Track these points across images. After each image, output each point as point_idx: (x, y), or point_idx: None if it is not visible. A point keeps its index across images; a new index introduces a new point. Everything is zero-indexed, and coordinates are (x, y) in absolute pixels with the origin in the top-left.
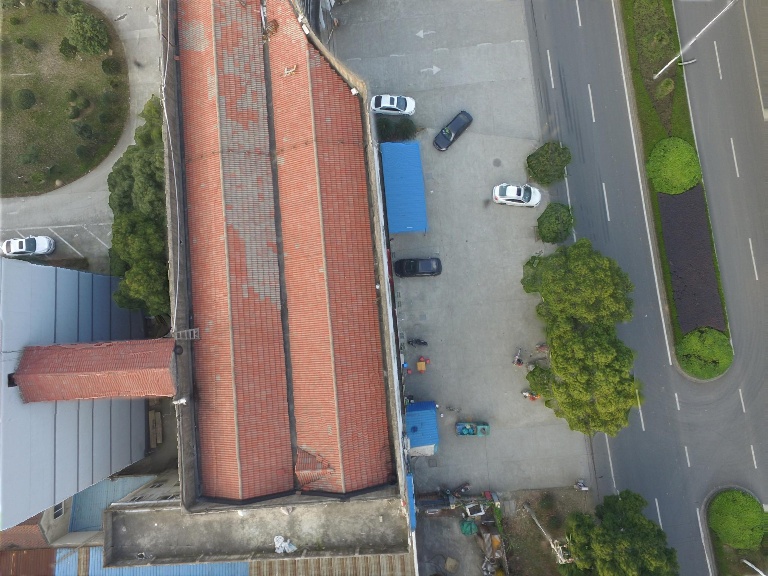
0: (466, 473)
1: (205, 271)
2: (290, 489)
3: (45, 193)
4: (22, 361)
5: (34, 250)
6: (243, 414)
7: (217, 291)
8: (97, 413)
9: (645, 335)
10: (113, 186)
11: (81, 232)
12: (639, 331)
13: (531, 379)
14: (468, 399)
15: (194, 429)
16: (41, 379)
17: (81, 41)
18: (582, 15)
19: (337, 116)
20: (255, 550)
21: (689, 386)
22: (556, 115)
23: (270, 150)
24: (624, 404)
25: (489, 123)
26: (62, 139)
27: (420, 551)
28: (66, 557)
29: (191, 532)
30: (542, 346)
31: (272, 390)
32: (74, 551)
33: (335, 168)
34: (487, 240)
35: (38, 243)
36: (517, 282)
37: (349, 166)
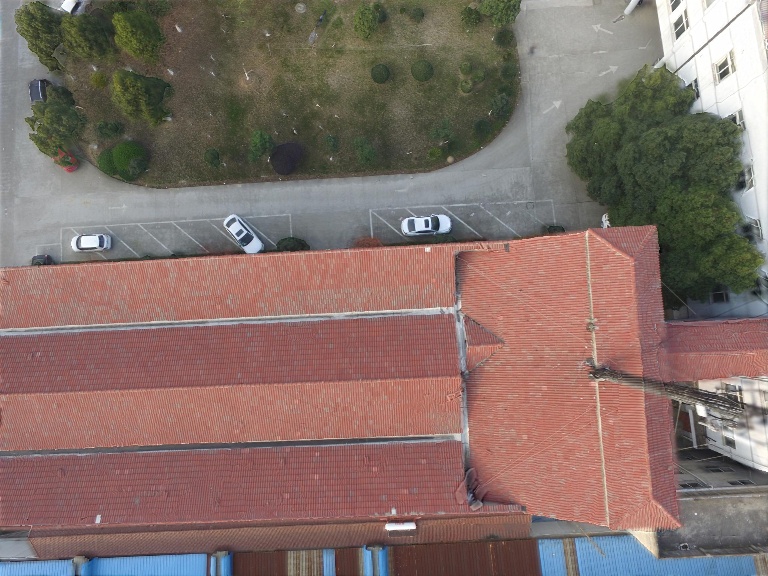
0: None
1: None
2: None
3: (435, 170)
4: None
5: (437, 229)
6: None
7: None
8: None
9: None
10: (634, 159)
11: (478, 211)
12: None
13: None
14: None
15: None
16: (680, 358)
17: (500, 10)
18: None
19: None
20: None
21: None
22: None
23: None
24: None
25: None
26: (452, 114)
27: None
28: (550, 548)
29: (735, 522)
30: None
31: None
32: (558, 542)
33: None
34: None
35: (441, 222)
36: None
37: None
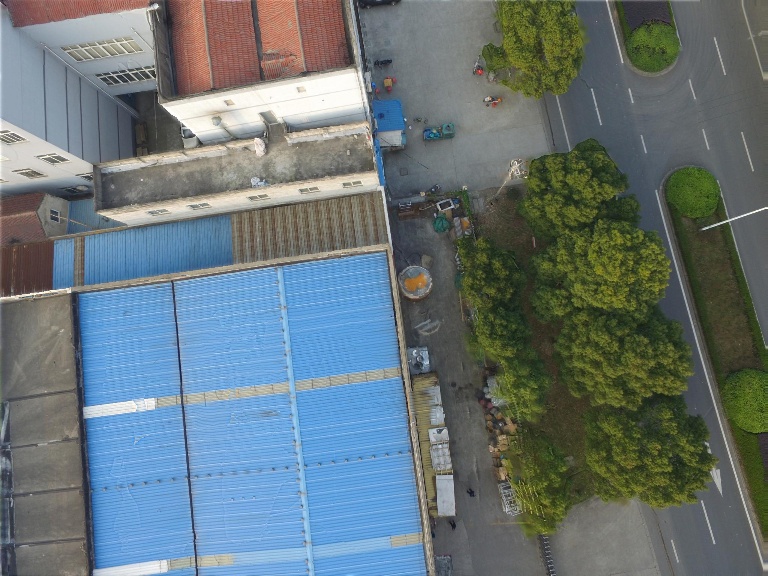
0: (436, 178)
1: None
2: None
3: None
4: None
5: None
6: (211, 18)
7: None
8: (85, 102)
9: (596, 35)
10: None
11: None
12: (588, 22)
13: (485, 50)
14: (434, 112)
15: (169, 49)
16: None
17: None
18: None
19: None
20: None
21: (641, 81)
22: None
23: None
24: (569, 38)
25: None
26: None
27: (392, 221)
28: (63, 247)
29: (174, 183)
30: None
31: (237, 3)
32: (70, 241)
33: None
34: None
35: None
36: (474, 4)
37: None
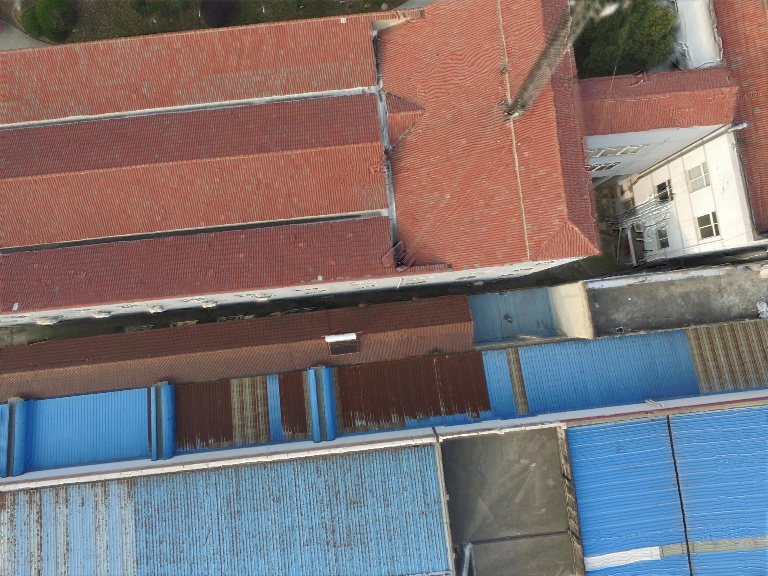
0: None
1: (725, 7)
2: None
3: None
4: None
5: None
6: None
7: (747, 24)
8: None
9: None
10: None
11: None
12: None
13: None
14: None
15: None
16: (596, 107)
17: None
18: None
19: None
20: (738, 317)
21: None
22: None
23: None
24: None
25: None
26: None
27: None
28: (493, 359)
29: (668, 304)
30: None
31: None
32: (501, 352)
33: None
34: None
35: None
36: None
37: None
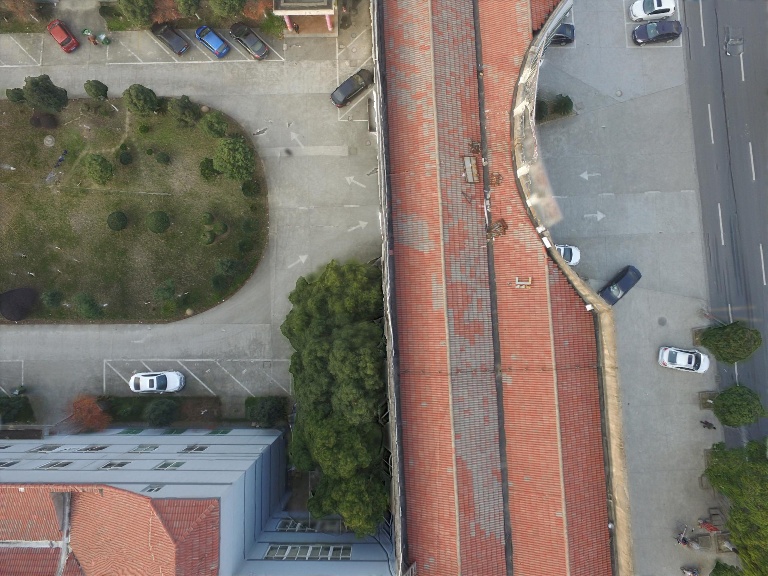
0: None
1: (425, 501)
2: None
3: (174, 322)
4: None
5: (165, 388)
6: None
7: (441, 527)
8: None
9: None
10: (296, 370)
11: (213, 368)
12: None
13: None
14: None
15: None
16: None
17: (229, 169)
18: (756, 169)
19: (574, 337)
20: None
21: None
22: (725, 274)
23: (494, 364)
24: None
25: (655, 278)
26: (194, 264)
27: None
28: None
29: None
30: (706, 522)
31: None
32: None
33: (572, 397)
34: (650, 404)
35: (169, 381)
36: (680, 451)
37: (585, 393)
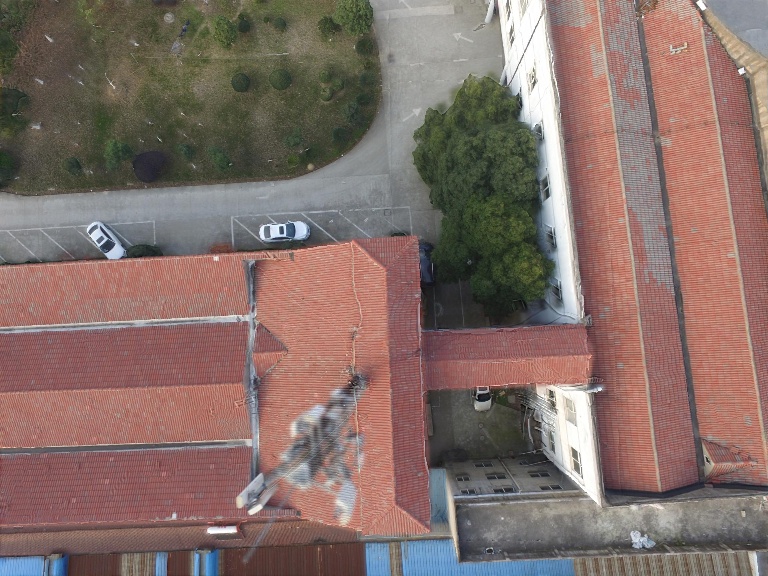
0: None
1: (597, 255)
2: (697, 482)
3: (296, 177)
4: (424, 347)
5: (293, 236)
6: (657, 404)
7: (615, 276)
8: None
9: None
10: (448, 168)
11: (336, 218)
12: None
13: None
14: None
15: None
16: (450, 366)
17: (351, 20)
18: None
19: (731, 96)
20: (611, 545)
21: None
22: None
23: (652, 131)
24: None
25: None
26: (313, 122)
27: None
28: (376, 552)
29: (541, 526)
30: None
31: (676, 379)
32: (384, 546)
33: (734, 150)
34: None
35: (297, 229)
36: None
37: (744, 148)
